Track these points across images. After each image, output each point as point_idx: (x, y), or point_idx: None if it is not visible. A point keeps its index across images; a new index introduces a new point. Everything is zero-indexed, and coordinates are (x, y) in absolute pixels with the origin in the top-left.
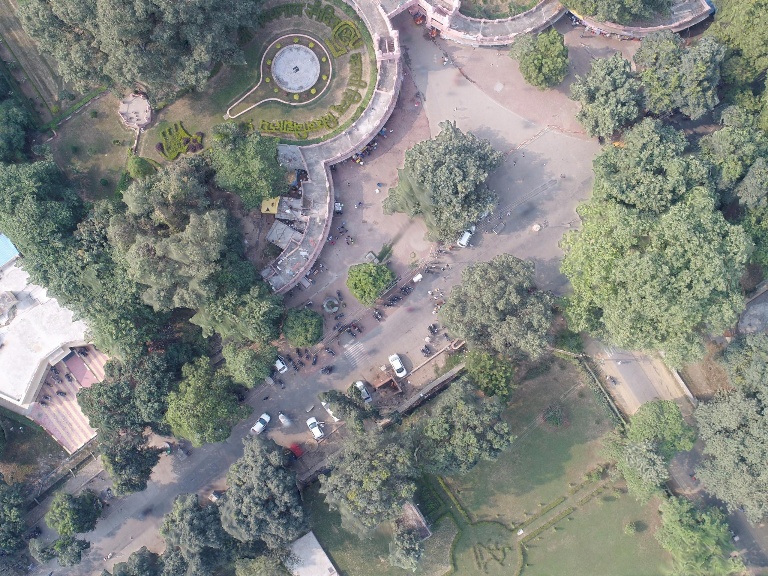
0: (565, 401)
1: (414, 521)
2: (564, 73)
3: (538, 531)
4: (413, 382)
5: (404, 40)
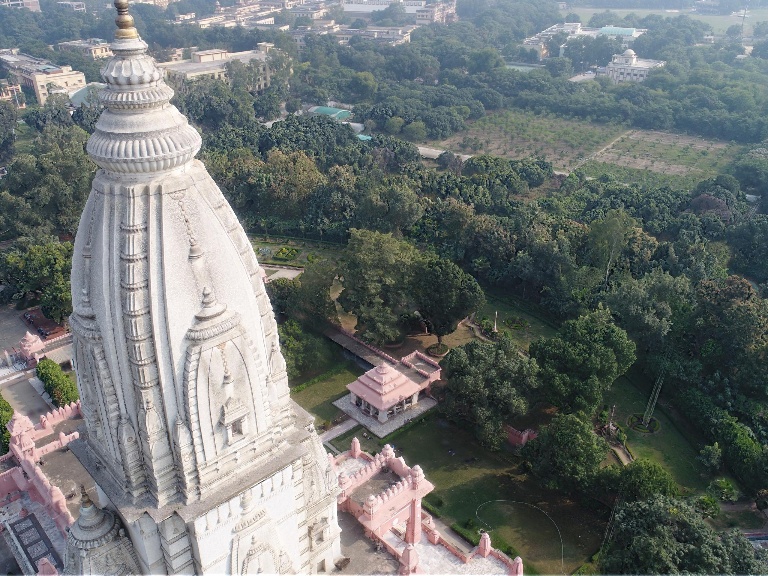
0: None
1: None
2: None
3: None
4: None
5: None
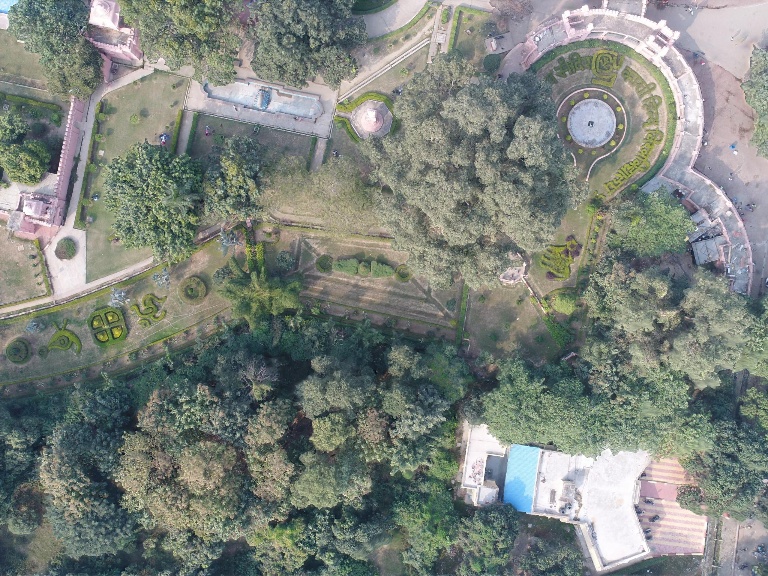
0: None
1: None
2: None
3: None
4: None
5: None
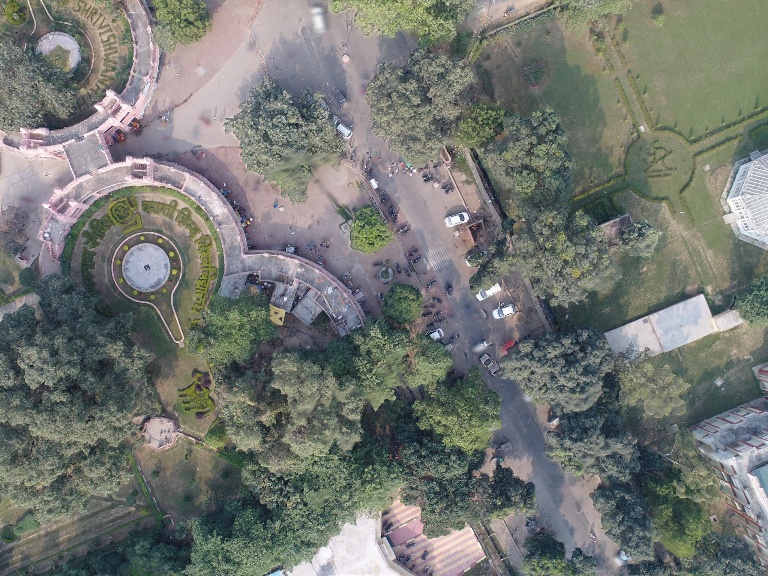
0: (521, 62)
1: (613, 229)
2: (198, 1)
3: (644, 111)
4: (476, 208)
5: (137, 156)
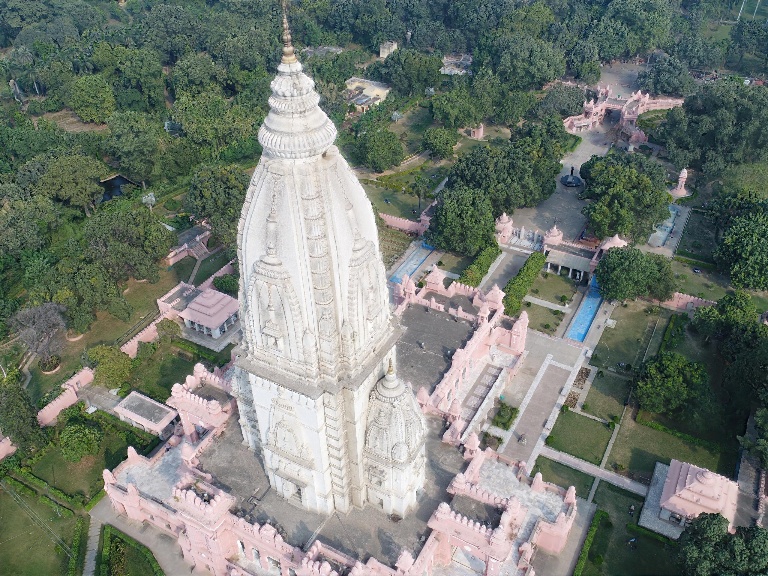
0: None
1: None
2: None
3: None
4: None
5: None
